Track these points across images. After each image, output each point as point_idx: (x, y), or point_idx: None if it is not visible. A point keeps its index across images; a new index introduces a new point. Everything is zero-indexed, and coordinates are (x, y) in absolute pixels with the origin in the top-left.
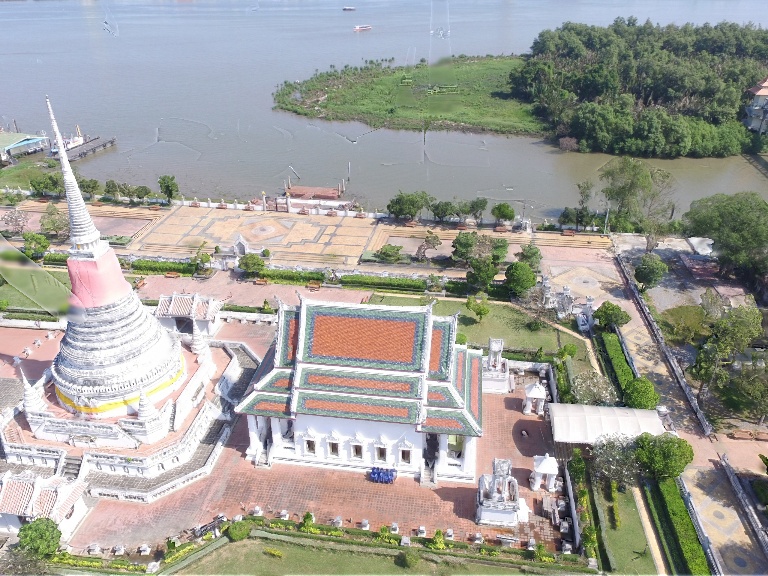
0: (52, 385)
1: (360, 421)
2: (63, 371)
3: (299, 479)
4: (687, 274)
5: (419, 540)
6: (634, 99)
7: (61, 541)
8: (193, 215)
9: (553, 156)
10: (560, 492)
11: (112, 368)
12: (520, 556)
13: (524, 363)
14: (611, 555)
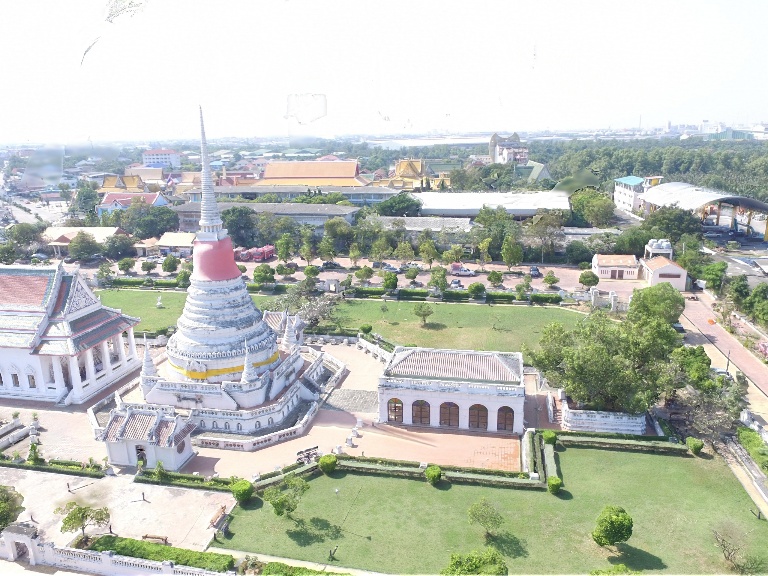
0: (286, 358)
1: None
2: None
3: None
4: None
5: None
6: None
7: None
8: None
9: None
10: None
11: None
12: None
13: None
14: None
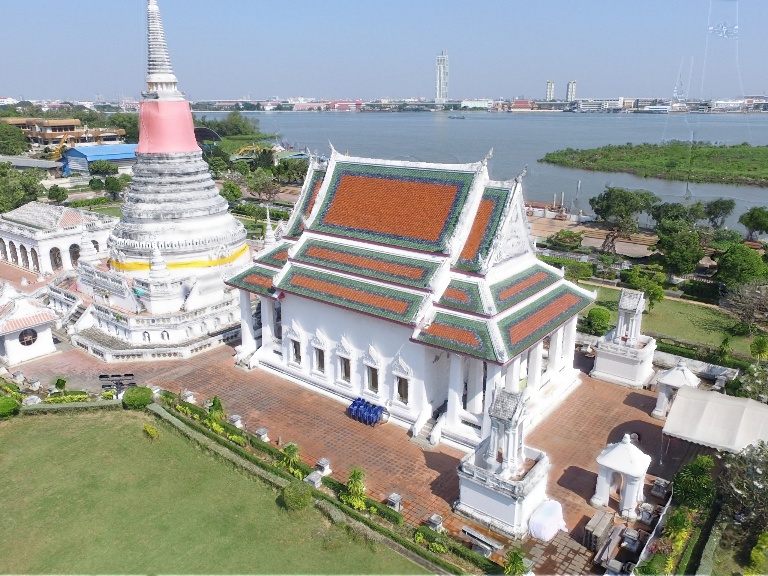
0: None
1: (350, 317)
2: None
3: (268, 389)
4: None
5: (333, 484)
6: None
7: (6, 364)
8: None
9: None
10: (645, 524)
11: (149, 225)
12: (481, 571)
13: (693, 362)
14: None
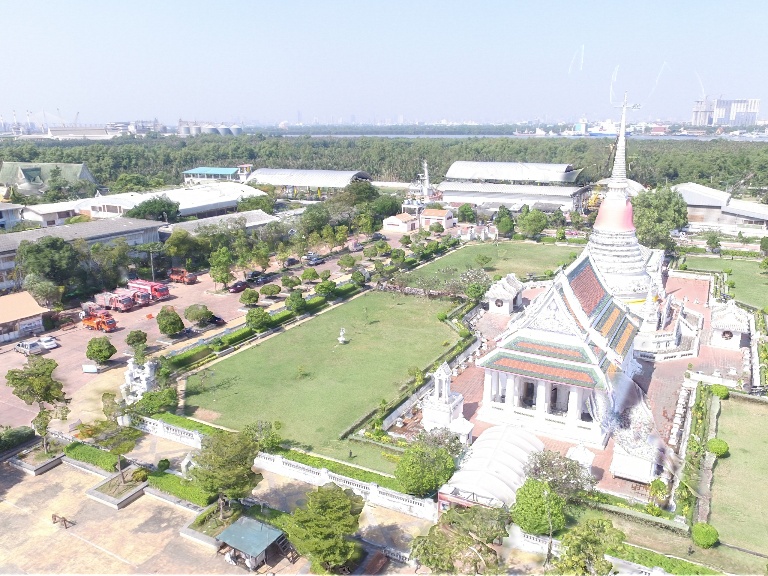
0: None
1: None
2: None
3: None
4: None
5: None
6: None
7: None
8: None
9: None
10: None
11: None
12: None
13: None
14: (360, 438)
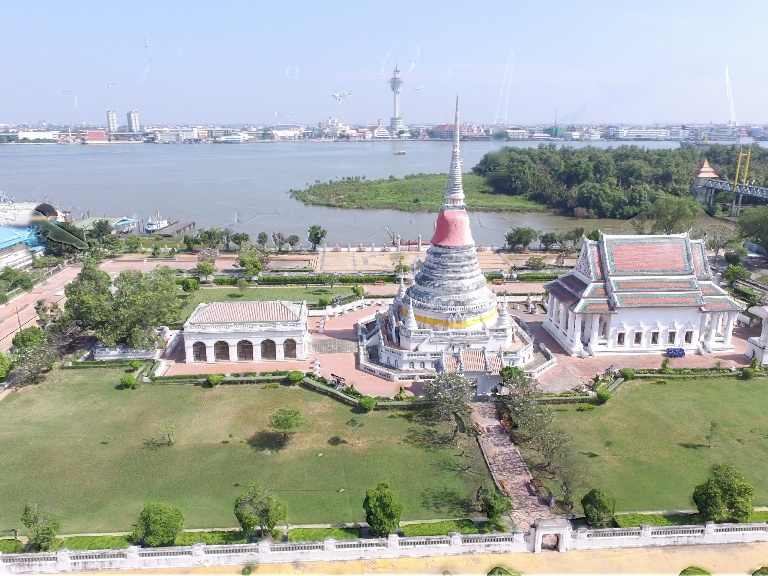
0: None
1: (660, 312)
2: (433, 299)
3: (621, 361)
4: (746, 264)
5: (741, 369)
6: (616, 181)
7: None
8: (343, 256)
9: (570, 222)
10: None
11: (472, 293)
12: None
13: None
14: None
